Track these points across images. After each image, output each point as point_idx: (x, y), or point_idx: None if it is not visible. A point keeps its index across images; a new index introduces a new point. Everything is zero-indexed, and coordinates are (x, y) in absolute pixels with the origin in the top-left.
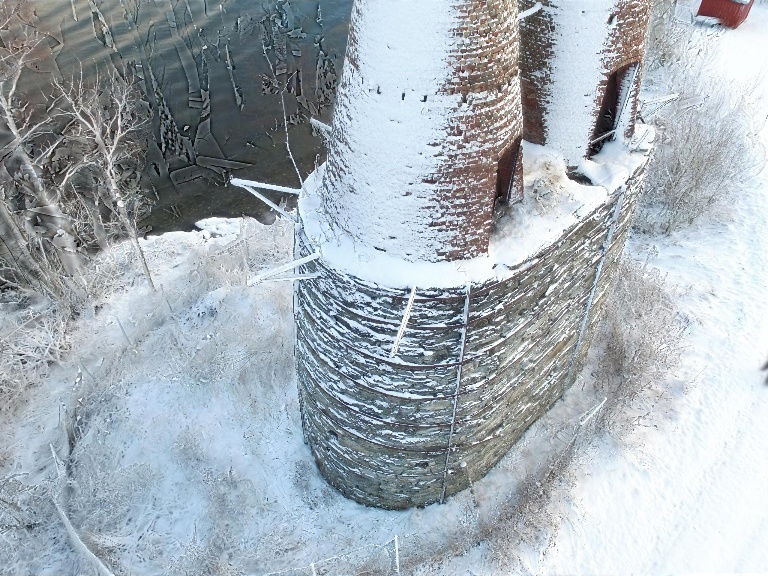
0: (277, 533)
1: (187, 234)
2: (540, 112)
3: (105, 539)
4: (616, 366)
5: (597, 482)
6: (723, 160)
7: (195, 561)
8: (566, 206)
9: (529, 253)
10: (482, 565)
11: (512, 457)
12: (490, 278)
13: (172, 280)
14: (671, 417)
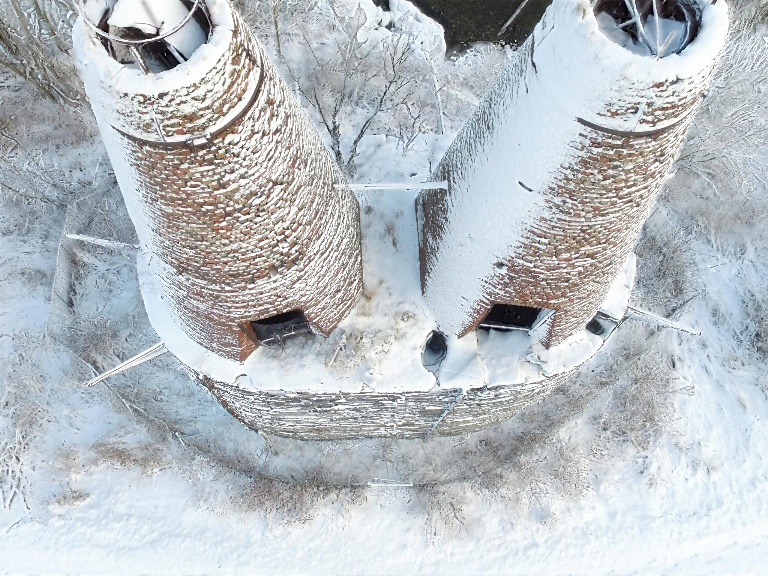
0: None
1: (369, 8)
2: (425, 269)
3: (85, 255)
4: (512, 452)
5: (381, 515)
6: None
7: (94, 326)
8: (360, 374)
9: (282, 387)
10: (238, 491)
11: (335, 446)
12: (227, 382)
13: (306, 57)
14: (504, 527)
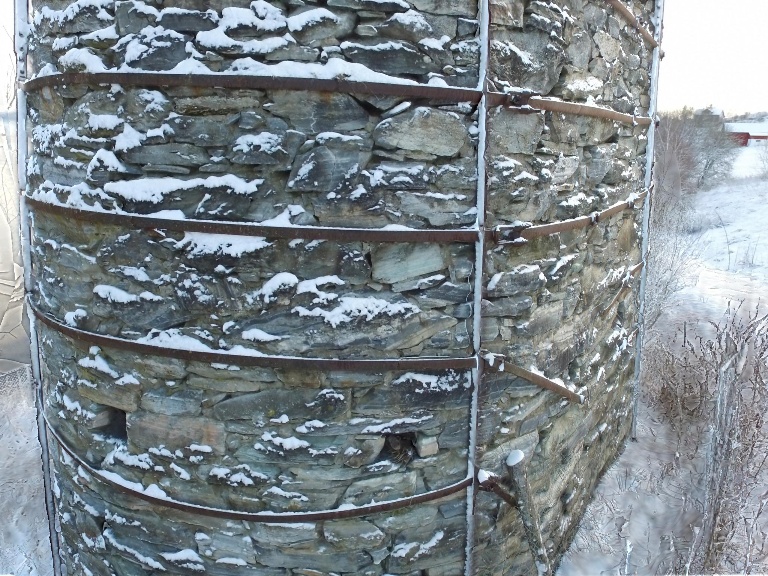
0: None
1: None
2: None
3: None
4: None
5: None
6: (667, 233)
7: None
8: None
9: None
10: None
11: (597, 528)
12: None
13: None
14: None
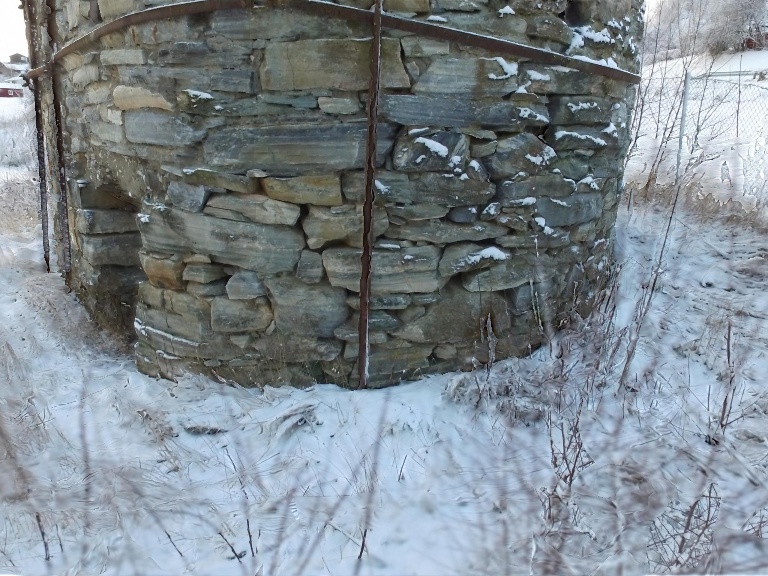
0: (759, 461)
1: None
2: None
3: None
4: None
5: None
6: None
7: None
8: None
9: None
10: None
11: None
12: None
13: None
14: None
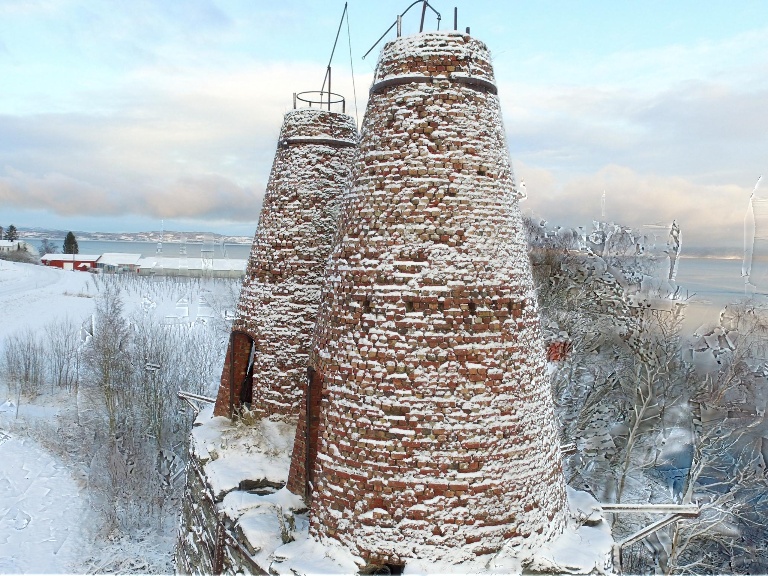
0: None
1: None
2: None
3: None
4: None
5: None
6: None
7: None
8: None
9: None
10: None
11: None
12: None
13: None
14: None
